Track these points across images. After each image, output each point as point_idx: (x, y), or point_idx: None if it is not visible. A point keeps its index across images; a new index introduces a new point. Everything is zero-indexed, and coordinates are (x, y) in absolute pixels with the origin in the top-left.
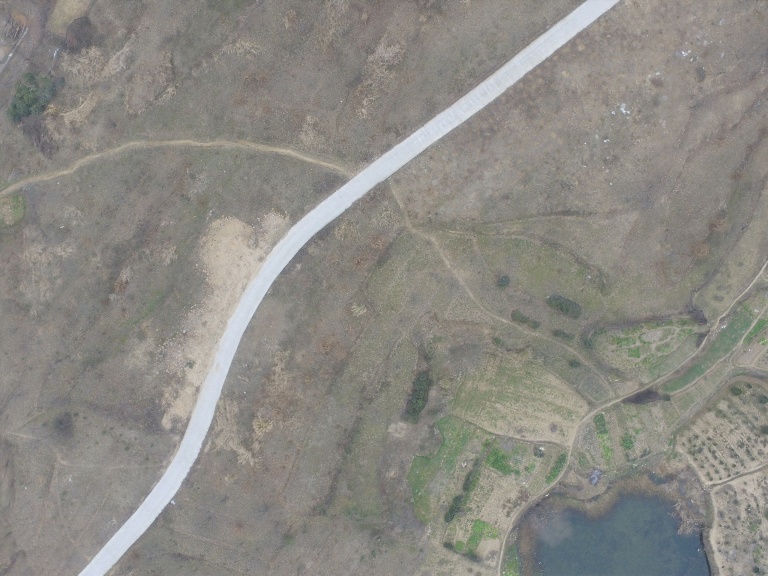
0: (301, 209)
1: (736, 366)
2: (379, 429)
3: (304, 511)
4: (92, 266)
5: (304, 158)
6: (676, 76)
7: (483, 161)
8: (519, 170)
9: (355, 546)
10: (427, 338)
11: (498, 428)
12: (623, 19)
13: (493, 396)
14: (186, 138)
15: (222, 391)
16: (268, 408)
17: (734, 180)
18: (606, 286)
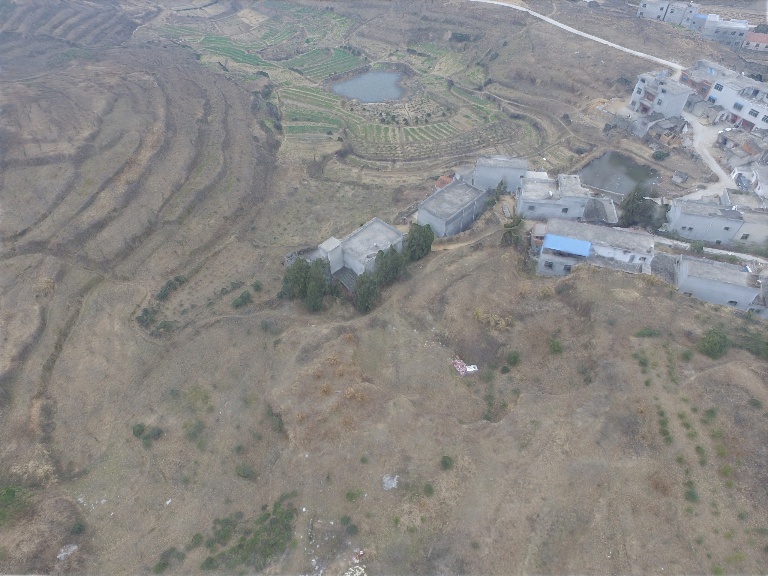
0: None
1: None
2: None
3: None
4: None
5: None
6: None
7: None
8: None
9: None
10: None
11: None
12: None
13: None
14: (557, 8)
15: None
16: None
17: None
18: None
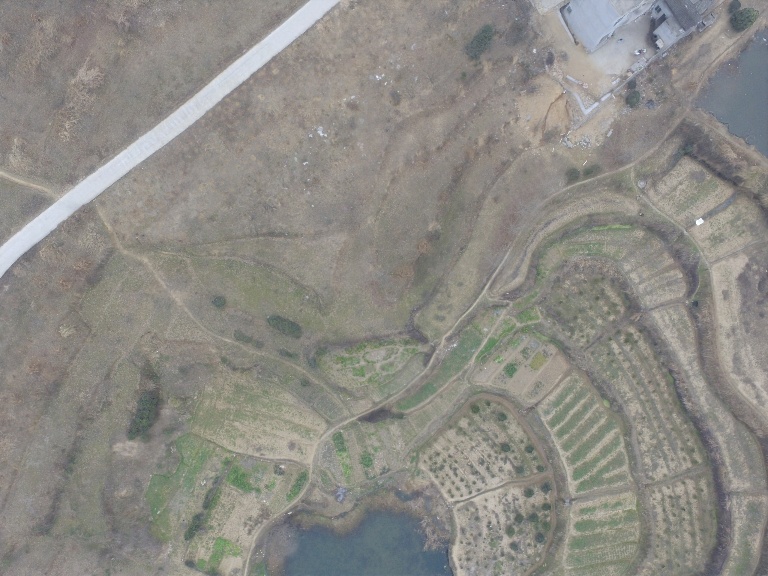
0: (9, 231)
1: (473, 384)
2: (102, 449)
3: (24, 531)
4: None
5: (16, 180)
6: (371, 100)
7: (187, 183)
8: (222, 192)
9: (84, 565)
10: (154, 358)
11: (237, 446)
12: (315, 43)
13: (231, 414)
14: None
15: None
16: None
17: (443, 201)
18: (322, 306)
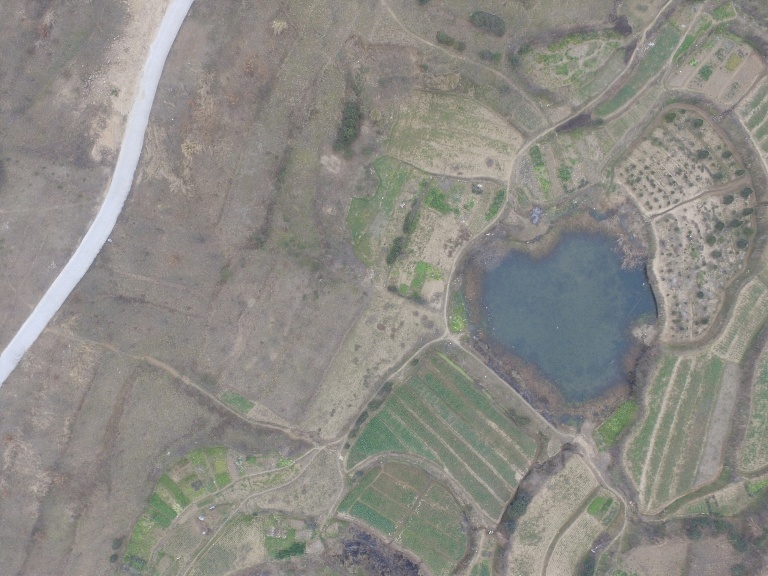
0: None
1: (668, 89)
2: (311, 159)
3: (241, 242)
4: (18, 19)
5: None
6: None
7: None
8: None
9: (296, 283)
10: (355, 69)
11: (434, 166)
12: None
13: (427, 134)
14: None
15: (150, 118)
16: (197, 134)
17: None
18: None
